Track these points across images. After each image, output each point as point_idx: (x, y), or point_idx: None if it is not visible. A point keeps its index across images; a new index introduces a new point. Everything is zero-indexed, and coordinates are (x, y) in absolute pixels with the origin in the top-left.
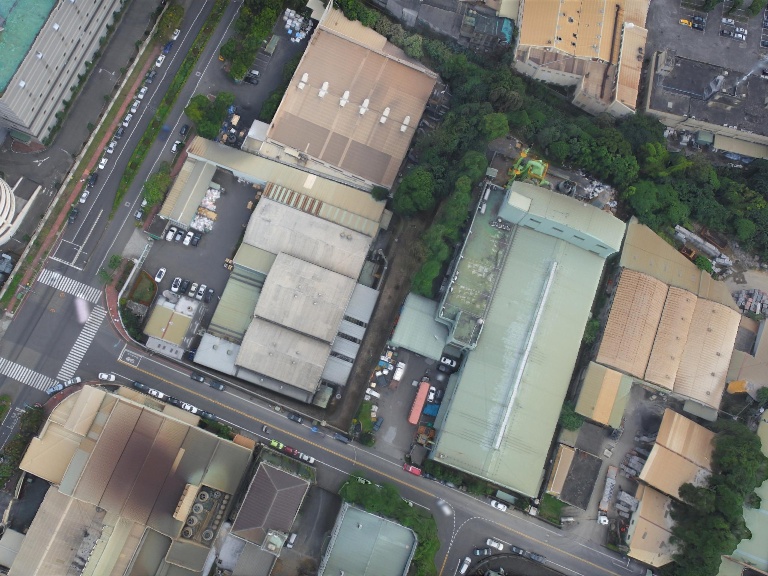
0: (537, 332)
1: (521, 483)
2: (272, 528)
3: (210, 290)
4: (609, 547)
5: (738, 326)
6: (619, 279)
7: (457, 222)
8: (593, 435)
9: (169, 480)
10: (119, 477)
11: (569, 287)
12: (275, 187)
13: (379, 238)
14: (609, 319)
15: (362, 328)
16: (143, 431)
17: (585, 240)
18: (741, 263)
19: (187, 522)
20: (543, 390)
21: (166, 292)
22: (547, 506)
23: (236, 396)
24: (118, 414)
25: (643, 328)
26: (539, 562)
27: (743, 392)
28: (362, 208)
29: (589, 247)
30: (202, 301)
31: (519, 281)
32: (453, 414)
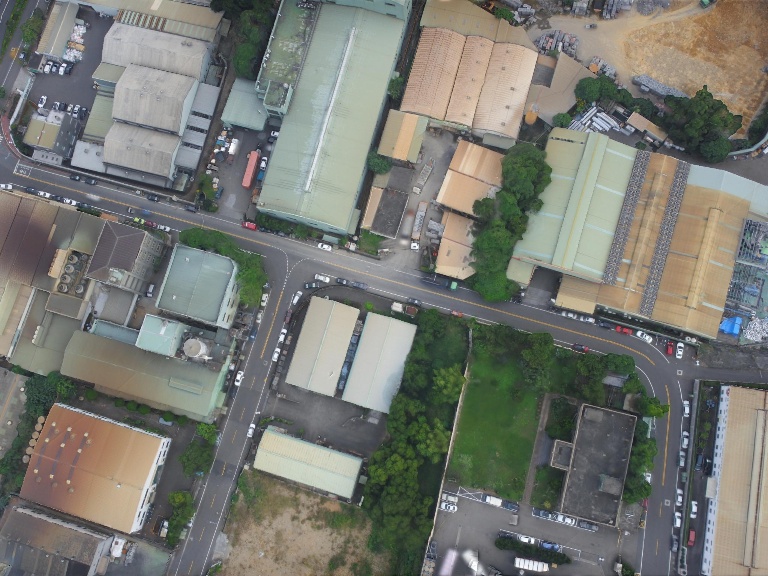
0: (339, 90)
1: (332, 219)
2: (115, 267)
3: (83, 108)
4: (422, 270)
5: (535, 64)
6: (420, 37)
7: (262, 5)
8: (402, 176)
9: (46, 249)
10: (7, 251)
11: (370, 49)
12: (126, 12)
13: (223, 46)
14: (411, 73)
15: (207, 120)
16: (22, 214)
17: (374, 1)
18: (545, 11)
19: (61, 280)
20: (349, 139)
21: (41, 110)
22: (366, 242)
23: (106, 188)
24: (1, 202)
25: (440, 75)
26: (361, 289)
27: (540, 121)
28: (202, 20)
29: (384, 10)
30: (78, 119)
31: (324, 50)
32: (271, 169)
